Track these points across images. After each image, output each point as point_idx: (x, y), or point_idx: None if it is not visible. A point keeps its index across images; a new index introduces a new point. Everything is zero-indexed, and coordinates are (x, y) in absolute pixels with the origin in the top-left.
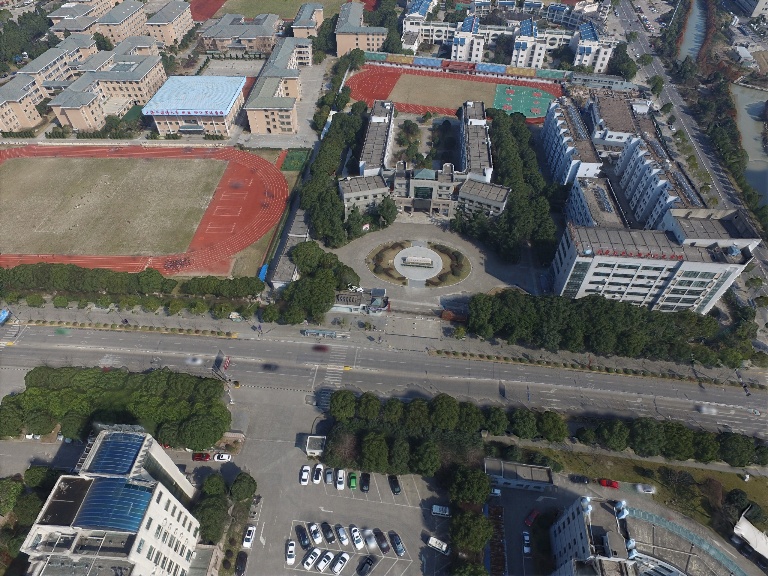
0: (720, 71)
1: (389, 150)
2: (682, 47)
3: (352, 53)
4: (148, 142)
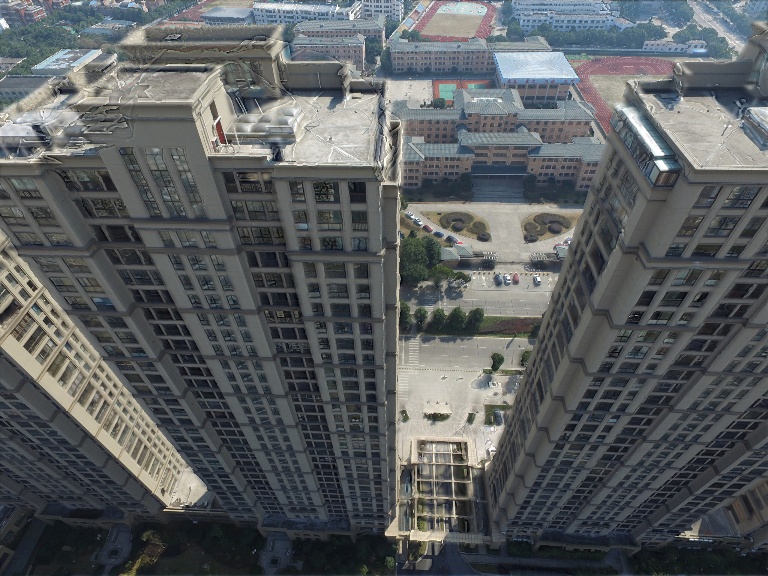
0: None
1: None
2: None
3: (416, 31)
4: None
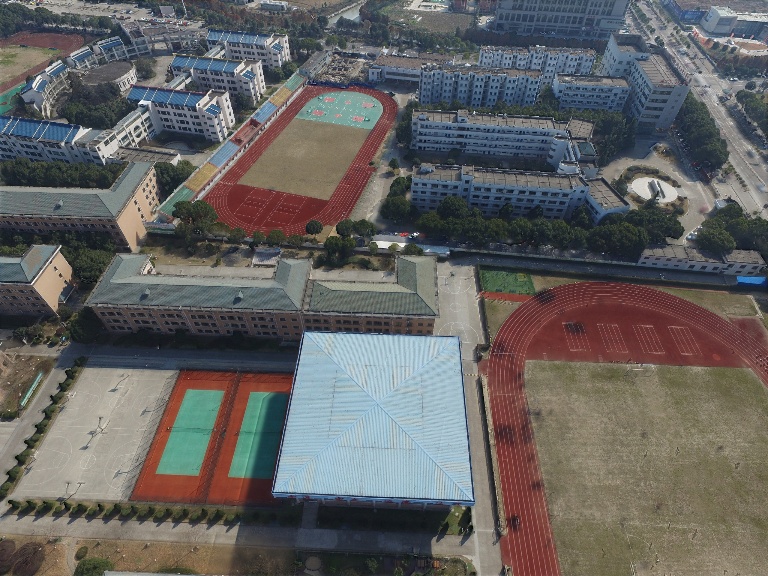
0: (298, 20)
1: None
2: None
3: (198, 209)
4: (484, 527)
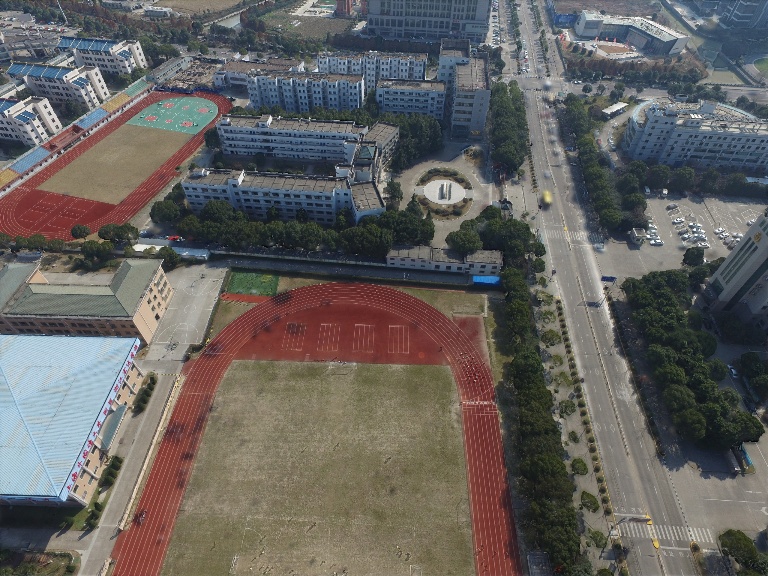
0: (177, 26)
1: None
2: None
3: None
4: (109, 523)
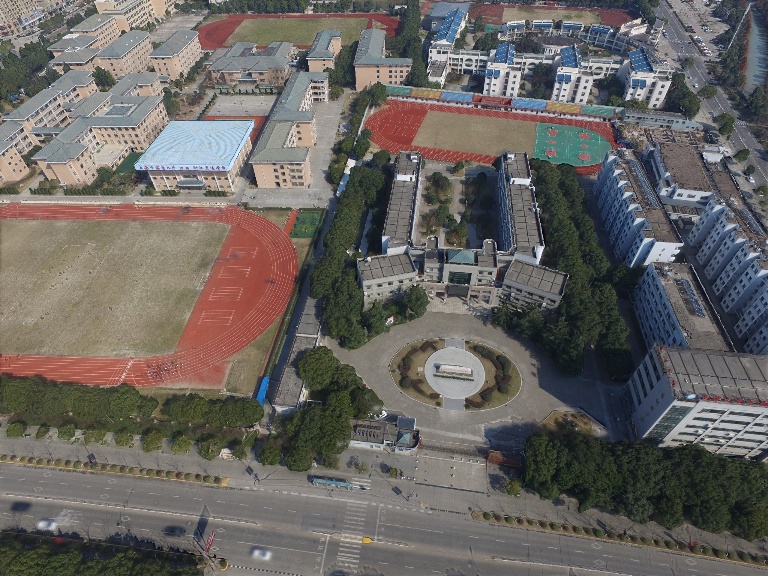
0: None
1: (416, 210)
2: (746, 74)
3: (373, 89)
4: (142, 199)
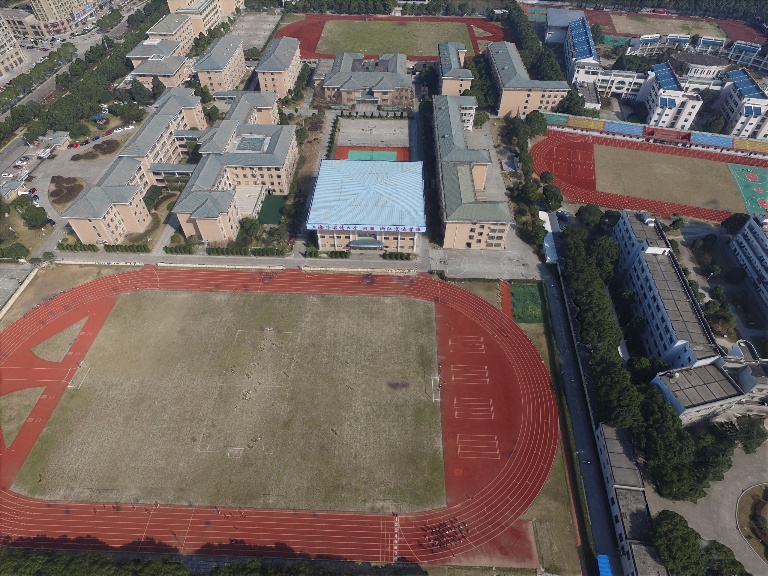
0: None
1: None
2: None
3: (533, 118)
4: (307, 263)
